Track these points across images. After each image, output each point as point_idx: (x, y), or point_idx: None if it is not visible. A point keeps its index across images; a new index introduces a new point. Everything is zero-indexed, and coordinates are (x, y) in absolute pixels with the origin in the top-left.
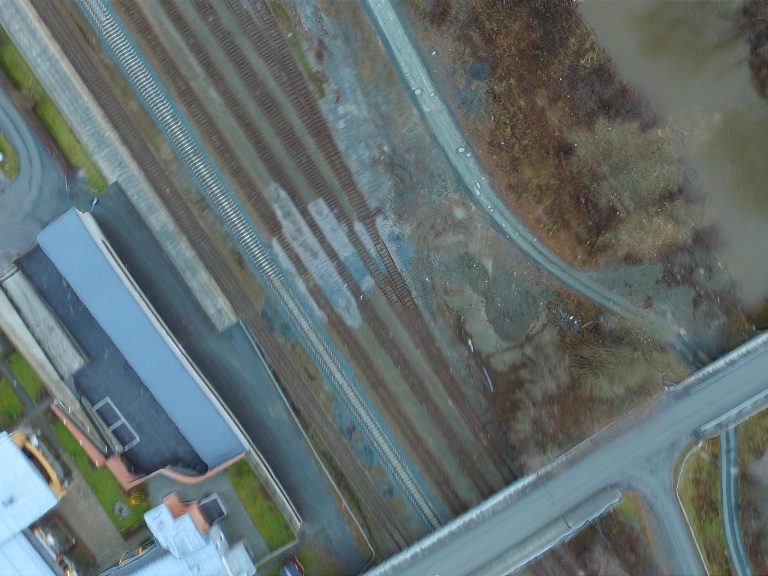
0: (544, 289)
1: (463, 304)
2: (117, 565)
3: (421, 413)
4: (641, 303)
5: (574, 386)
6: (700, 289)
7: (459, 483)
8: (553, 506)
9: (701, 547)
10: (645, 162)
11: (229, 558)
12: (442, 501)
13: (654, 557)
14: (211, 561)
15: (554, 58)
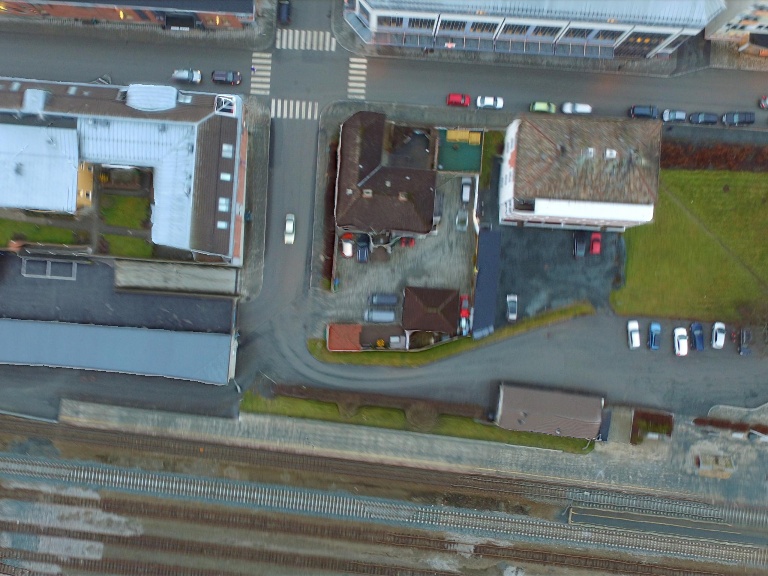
0: None
1: None
2: None
3: None
4: None
5: None
6: None
7: None
8: None
9: None
10: None
11: None
12: None
13: None
14: None
15: None
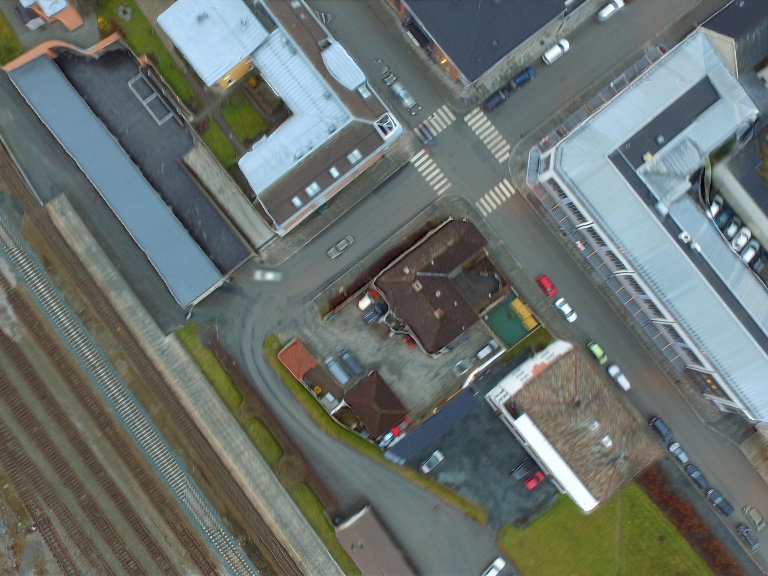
0: None
1: None
2: None
3: None
4: None
5: None
6: None
7: None
8: None
9: None
10: None
11: None
12: None
13: None
14: None
15: None
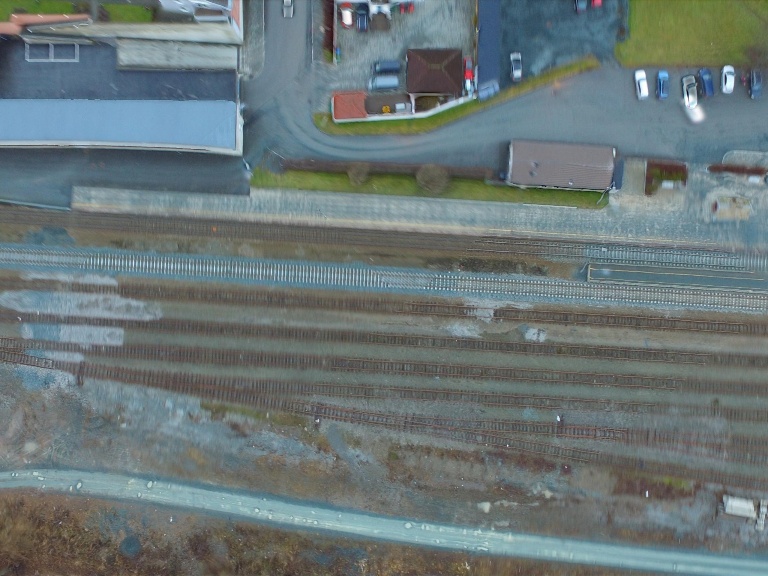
0: None
1: None
2: None
3: None
4: None
5: None
6: None
7: None
8: None
9: None
10: None
11: None
12: None
13: None
14: None
15: None
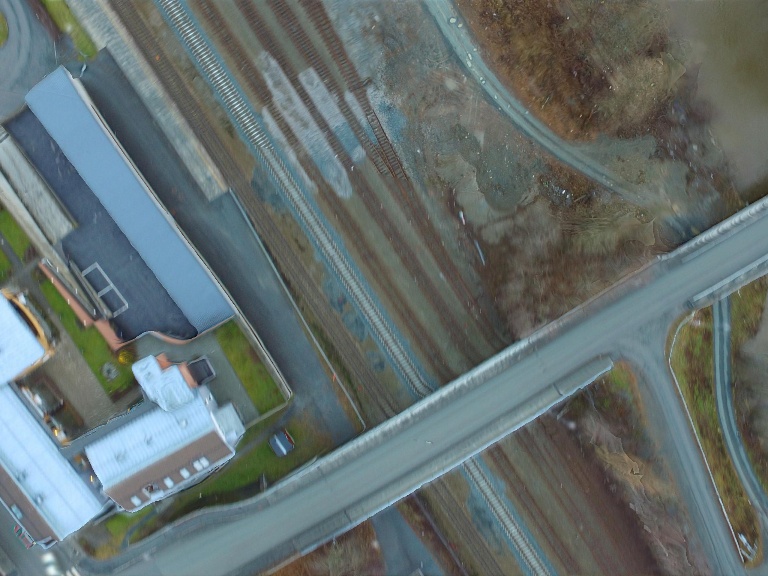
0: (536, 162)
1: (454, 175)
2: (105, 424)
3: (412, 286)
4: (634, 178)
5: (565, 247)
6: (693, 165)
7: (450, 357)
8: (545, 374)
9: (694, 421)
10: (638, 36)
11: (218, 415)
12: (433, 373)
13: (646, 430)
14: (199, 415)
15: None
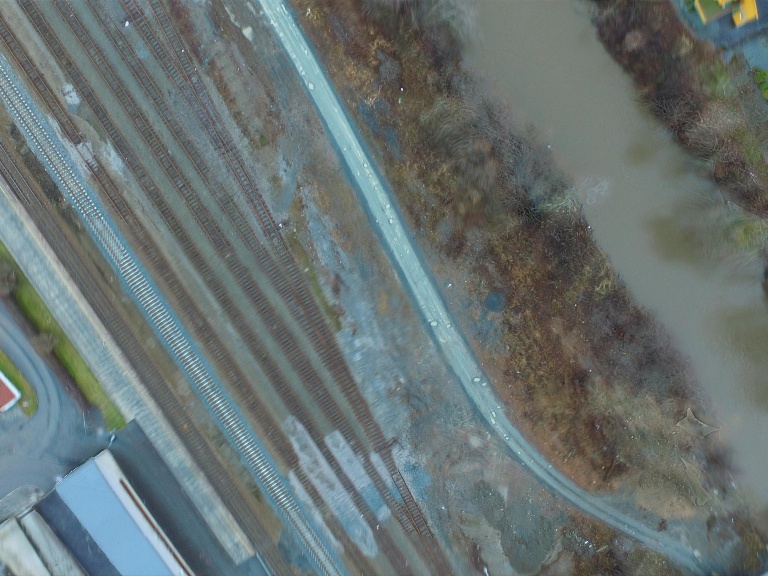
0: (559, 515)
1: (479, 534)
2: None
3: None
4: (655, 526)
5: None
6: (714, 510)
7: None
8: None
9: None
10: (659, 386)
11: None
12: None
13: None
14: None
15: (569, 285)
